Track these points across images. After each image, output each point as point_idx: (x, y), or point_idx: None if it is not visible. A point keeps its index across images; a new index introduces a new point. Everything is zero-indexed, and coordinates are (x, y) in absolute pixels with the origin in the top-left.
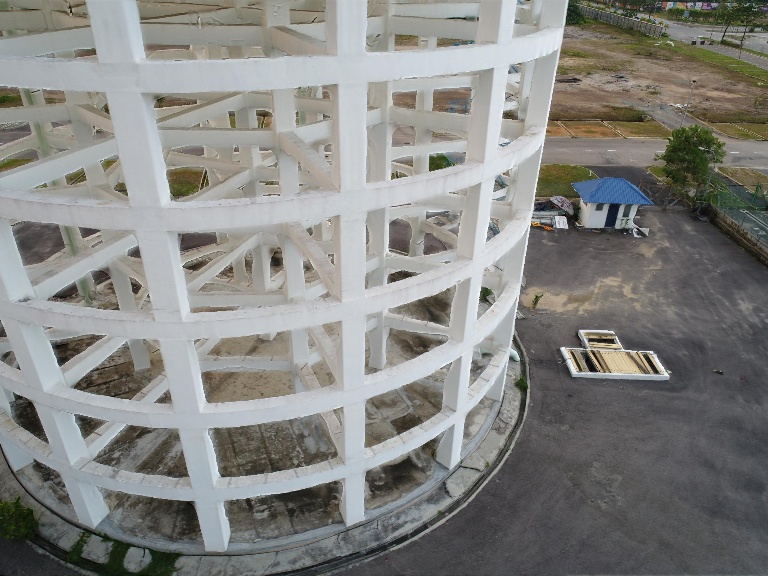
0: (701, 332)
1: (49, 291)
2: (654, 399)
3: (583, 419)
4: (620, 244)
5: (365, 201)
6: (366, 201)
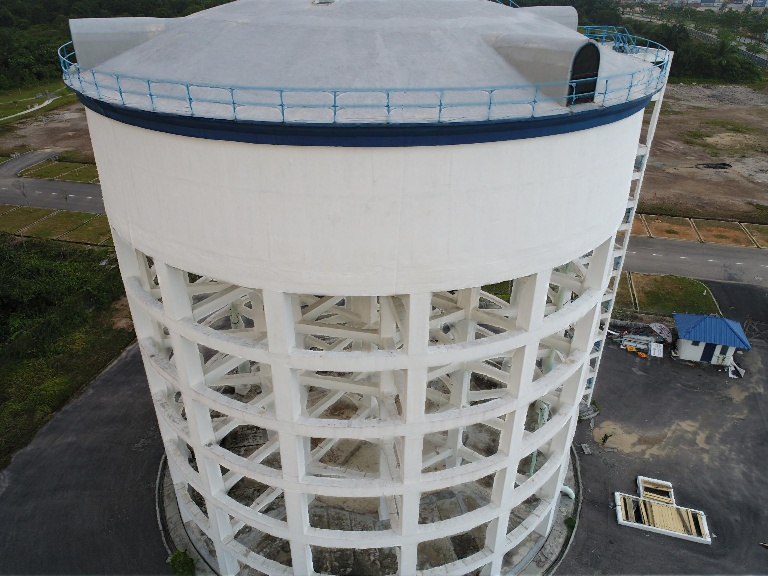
0: (762, 498)
1: (223, 434)
2: (690, 561)
3: (616, 568)
4: (711, 383)
5: (423, 429)
6: (424, 429)
